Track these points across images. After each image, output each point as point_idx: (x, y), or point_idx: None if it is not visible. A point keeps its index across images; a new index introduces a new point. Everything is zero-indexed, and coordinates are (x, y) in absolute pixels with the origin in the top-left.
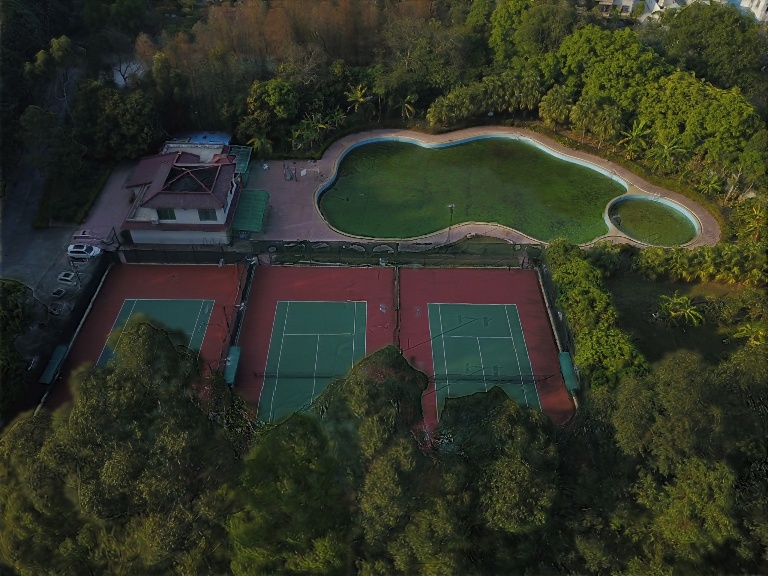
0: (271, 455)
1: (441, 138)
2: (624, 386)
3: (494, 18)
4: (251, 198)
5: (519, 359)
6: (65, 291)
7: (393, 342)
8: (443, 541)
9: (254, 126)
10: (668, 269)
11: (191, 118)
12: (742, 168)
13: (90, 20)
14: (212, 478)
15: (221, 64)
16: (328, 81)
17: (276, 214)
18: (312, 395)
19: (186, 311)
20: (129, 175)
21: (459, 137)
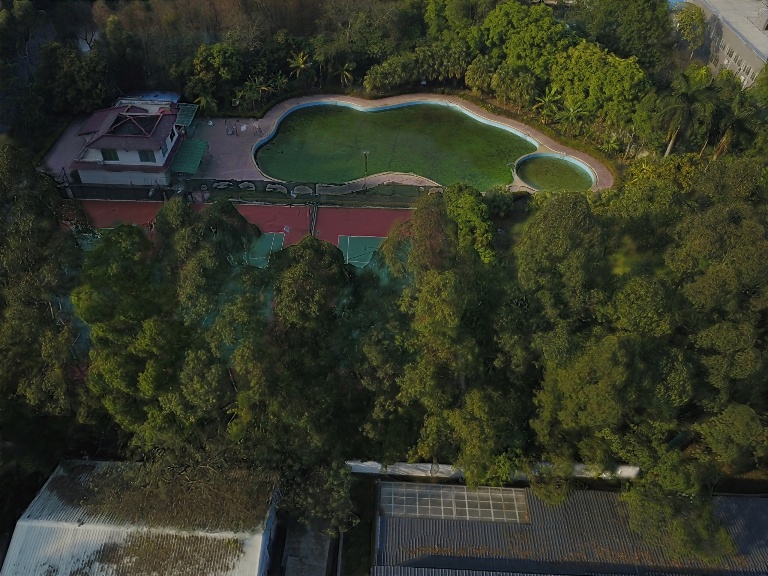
0: (106, 250)
1: (376, 103)
2: None
3: None
4: (191, 146)
5: None
6: None
7: None
8: (244, 329)
9: (200, 85)
10: None
11: (144, 79)
12: (635, 128)
13: None
14: (56, 257)
15: (172, 29)
16: (272, 48)
17: (215, 162)
18: None
19: None
20: (82, 125)
21: (392, 102)
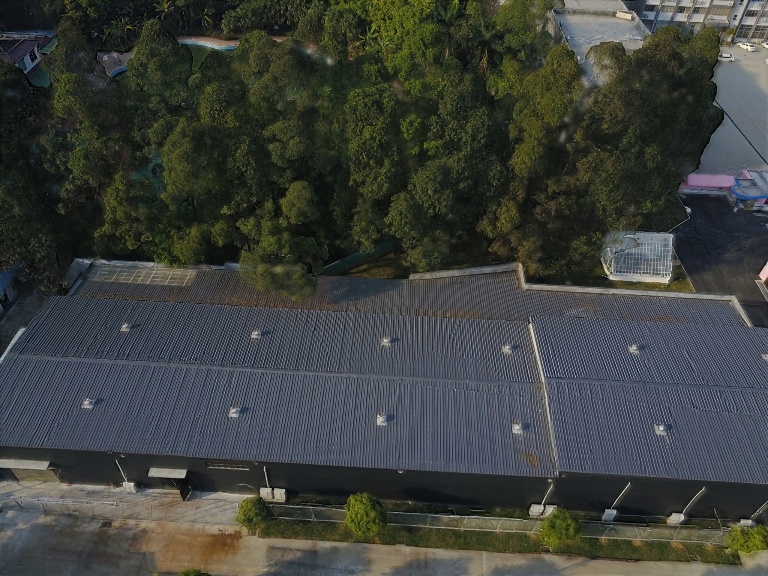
0: None
1: (230, 43)
2: None
3: None
4: None
5: None
6: None
7: None
8: None
9: None
10: None
11: (27, 18)
12: None
13: None
14: None
15: None
16: None
17: None
18: None
19: None
20: None
21: None
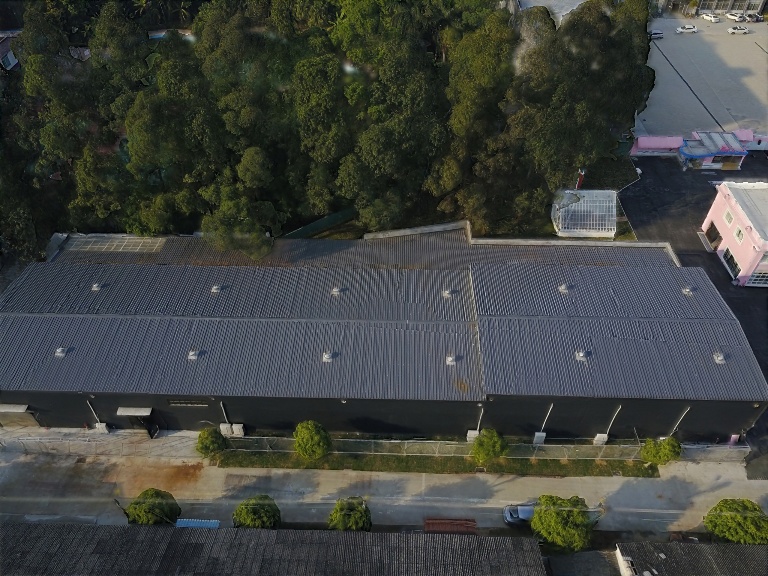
0: None
1: None
2: None
3: None
4: None
5: None
6: None
7: None
8: None
9: (51, 19)
10: None
11: (11, 18)
12: None
13: None
14: None
15: None
16: None
17: None
18: None
19: None
20: None
21: None
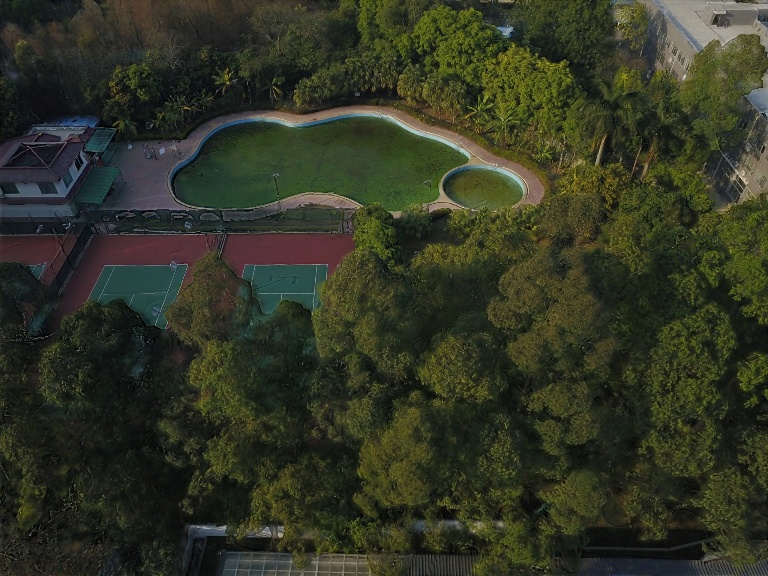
0: None
1: (306, 118)
2: None
3: (362, 3)
4: (100, 174)
5: None
6: None
7: None
8: (5, 413)
9: (116, 108)
10: (474, 229)
11: (62, 103)
12: (565, 136)
13: None
14: None
15: (87, 51)
16: (195, 66)
17: (128, 189)
18: None
19: None
20: None
21: (323, 116)
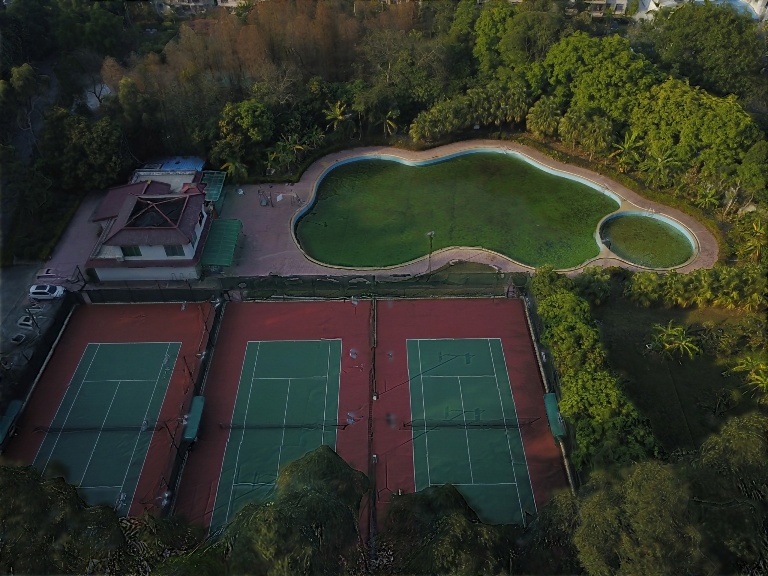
0: None
1: (425, 155)
2: (592, 486)
3: (478, 26)
4: (222, 229)
5: (502, 400)
6: (25, 336)
7: (368, 385)
8: None
9: (227, 150)
10: (662, 295)
11: (163, 143)
12: (741, 181)
13: (65, 40)
14: None
15: (192, 86)
16: (305, 99)
17: (250, 244)
18: (281, 447)
19: (151, 355)
20: (96, 207)
21: (444, 153)
